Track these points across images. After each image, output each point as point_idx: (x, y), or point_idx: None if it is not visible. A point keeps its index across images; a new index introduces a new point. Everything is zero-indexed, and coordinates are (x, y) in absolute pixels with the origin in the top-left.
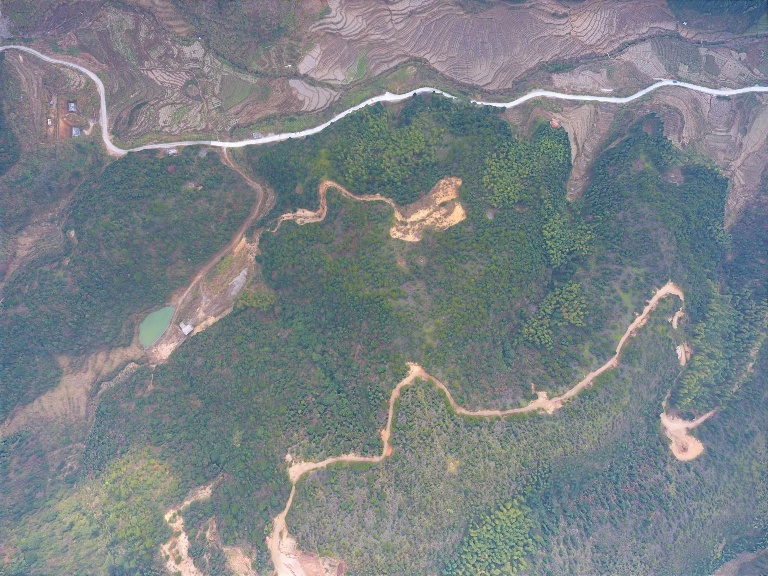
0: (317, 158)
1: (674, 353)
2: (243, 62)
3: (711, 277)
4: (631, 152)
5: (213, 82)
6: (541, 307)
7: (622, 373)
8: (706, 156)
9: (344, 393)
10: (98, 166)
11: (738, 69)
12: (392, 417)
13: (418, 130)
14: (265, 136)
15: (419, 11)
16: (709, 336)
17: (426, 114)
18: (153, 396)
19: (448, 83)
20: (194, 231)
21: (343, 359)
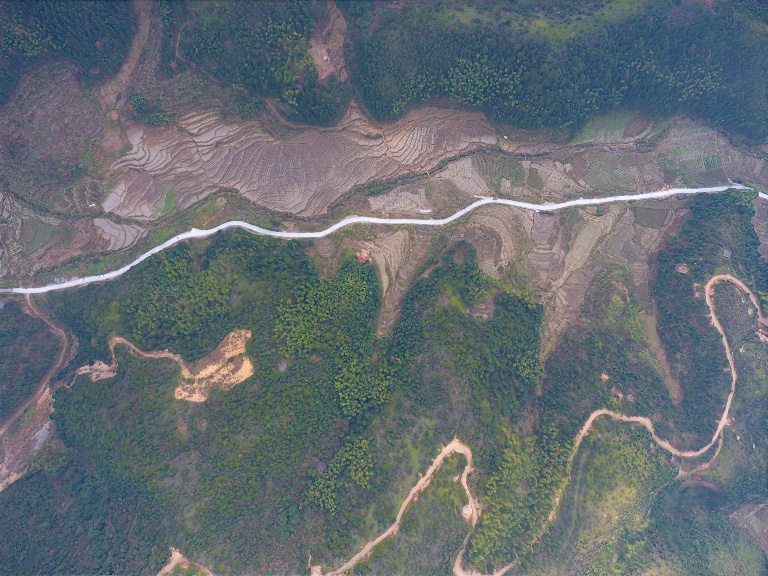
0: (105, 313)
1: (458, 516)
2: (43, 205)
3: (513, 420)
4: (438, 285)
5: (13, 227)
6: (329, 466)
7: (399, 544)
8: (528, 276)
9: (116, 574)
10: None
11: (563, 181)
12: None
13: (213, 276)
14: (69, 280)
15: (226, 141)
16: (501, 491)
17: (224, 257)
18: None
19: (260, 213)
20: None
21: (117, 537)
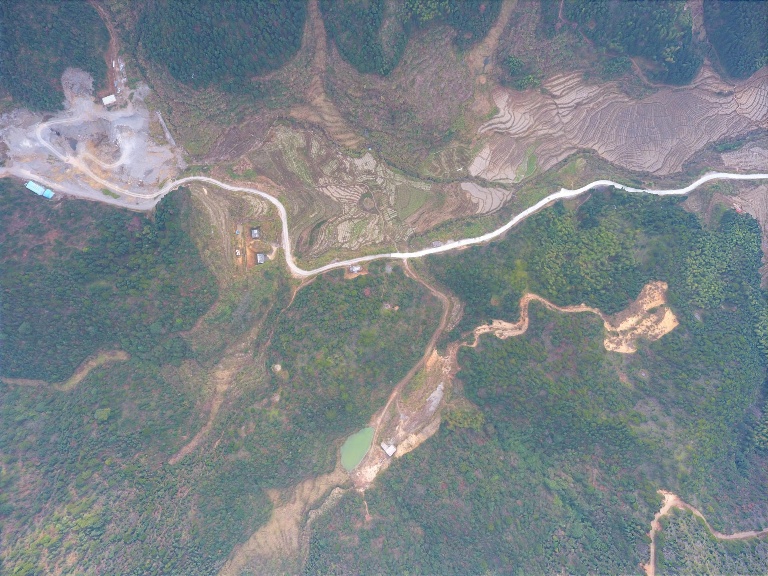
0: (516, 271)
1: None
2: (416, 170)
3: None
4: None
5: (387, 193)
6: (767, 411)
7: None
8: None
9: (589, 522)
10: (286, 291)
11: None
12: (656, 551)
13: (610, 232)
14: (444, 244)
15: (585, 102)
16: None
17: (614, 213)
18: (377, 529)
19: (619, 172)
20: (396, 354)
21: (581, 485)
